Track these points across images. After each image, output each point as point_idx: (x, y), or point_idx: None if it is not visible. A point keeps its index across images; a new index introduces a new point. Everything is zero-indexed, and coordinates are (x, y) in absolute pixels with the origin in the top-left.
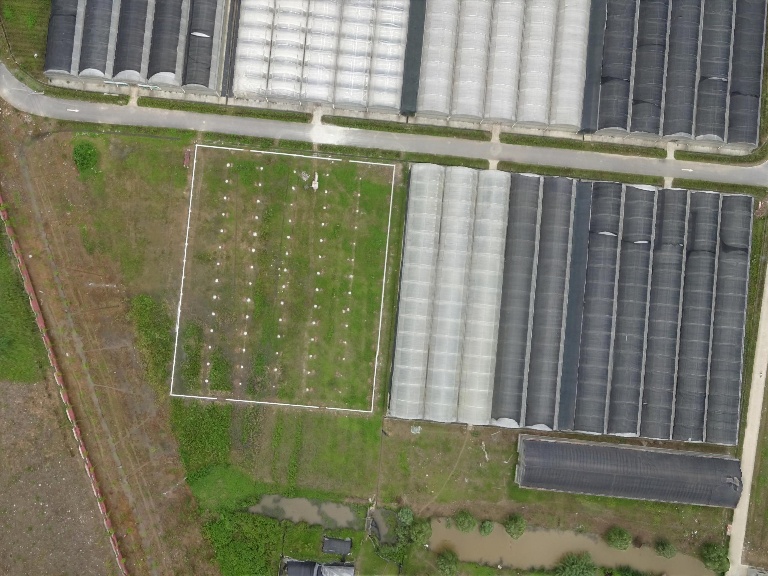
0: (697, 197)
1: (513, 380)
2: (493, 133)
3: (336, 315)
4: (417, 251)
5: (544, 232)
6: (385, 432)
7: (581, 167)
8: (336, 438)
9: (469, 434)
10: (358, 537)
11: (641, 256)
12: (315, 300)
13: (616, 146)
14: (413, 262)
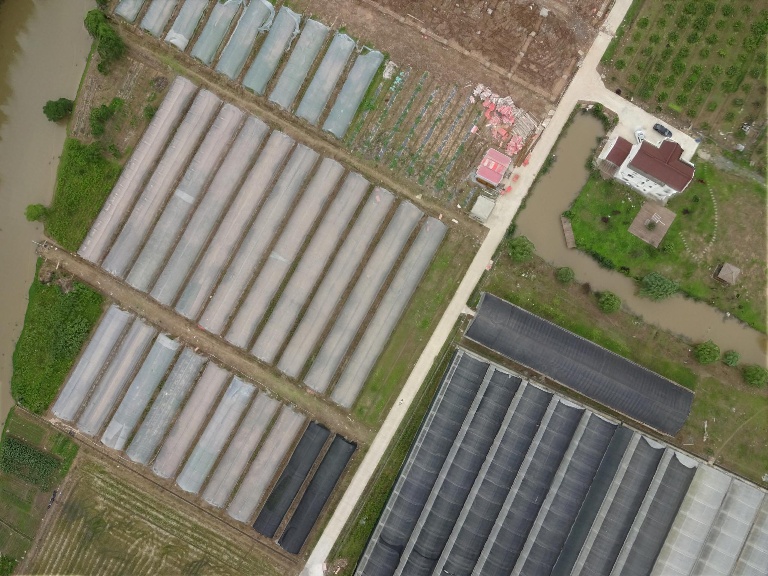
0: None
1: (667, 502)
2: None
3: None
4: None
5: None
6: None
7: None
8: None
9: (715, 454)
10: None
11: None
12: None
13: None
14: None
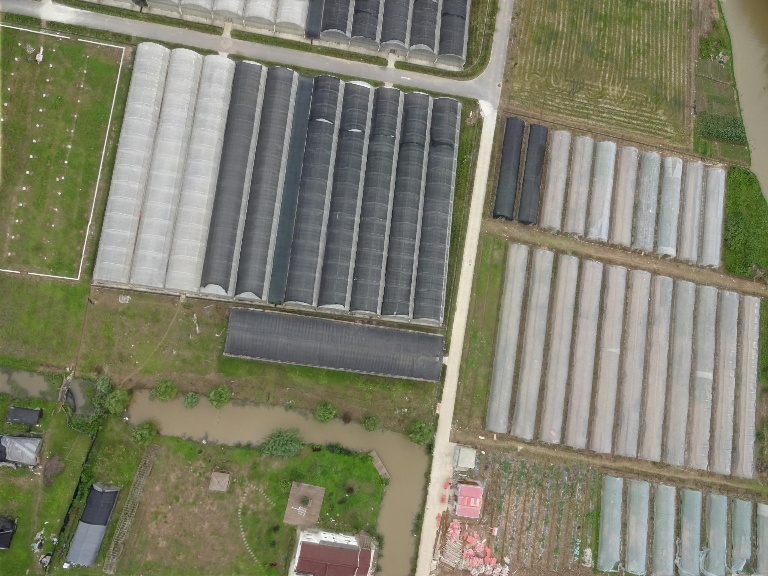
0: (409, 97)
1: (223, 248)
2: (225, 29)
3: (49, 182)
4: (135, 123)
5: (264, 116)
6: (91, 300)
7: (307, 66)
8: (36, 304)
9: (181, 306)
10: (50, 408)
11: (354, 143)
12: (28, 166)
13: (341, 52)
14: (129, 131)
